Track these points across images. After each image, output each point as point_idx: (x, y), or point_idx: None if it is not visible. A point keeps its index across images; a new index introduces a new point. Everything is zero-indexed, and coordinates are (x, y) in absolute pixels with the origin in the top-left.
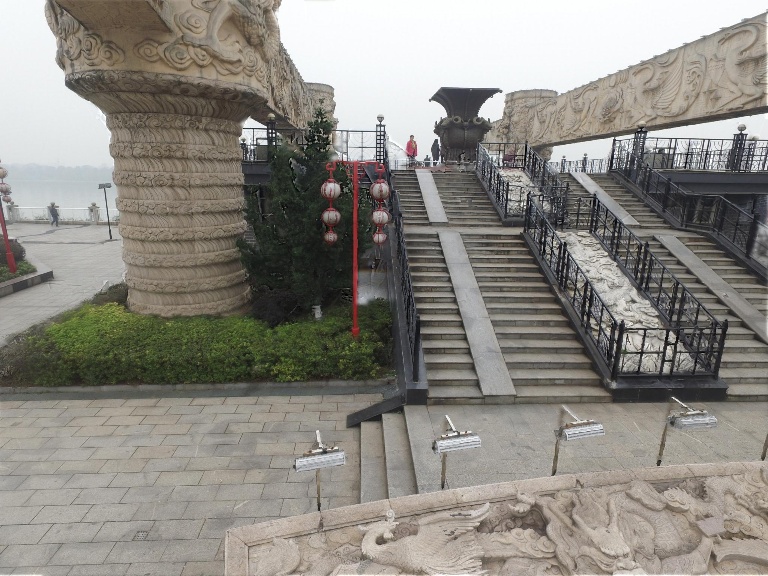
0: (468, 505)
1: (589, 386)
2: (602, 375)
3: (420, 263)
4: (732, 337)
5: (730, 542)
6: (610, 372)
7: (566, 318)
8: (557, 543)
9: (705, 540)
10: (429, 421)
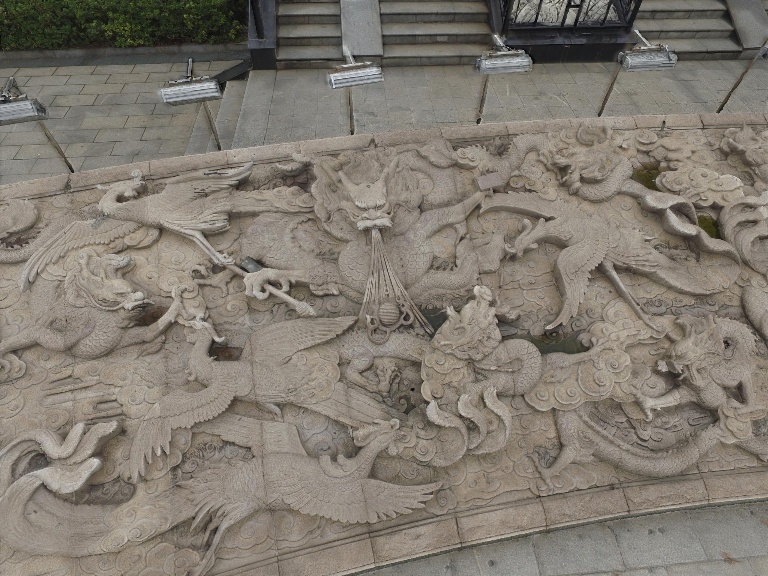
0: (240, 166)
1: (477, 44)
2: (493, 29)
3: None
4: None
5: (503, 195)
6: (502, 24)
7: None
8: (317, 199)
9: (476, 194)
10: (272, 87)
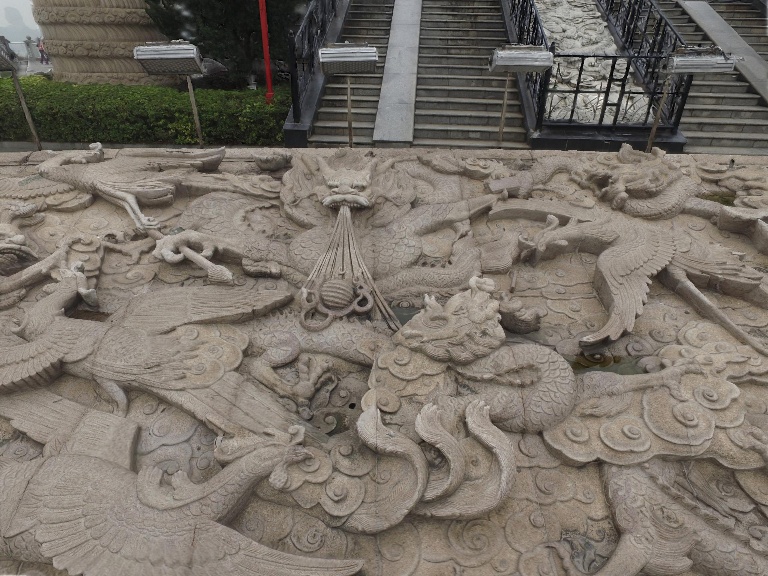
0: None
1: (510, 141)
2: (527, 126)
3: (361, 26)
4: (727, 102)
5: (522, 201)
6: (536, 121)
7: (514, 77)
8: (287, 184)
9: None
10: None
